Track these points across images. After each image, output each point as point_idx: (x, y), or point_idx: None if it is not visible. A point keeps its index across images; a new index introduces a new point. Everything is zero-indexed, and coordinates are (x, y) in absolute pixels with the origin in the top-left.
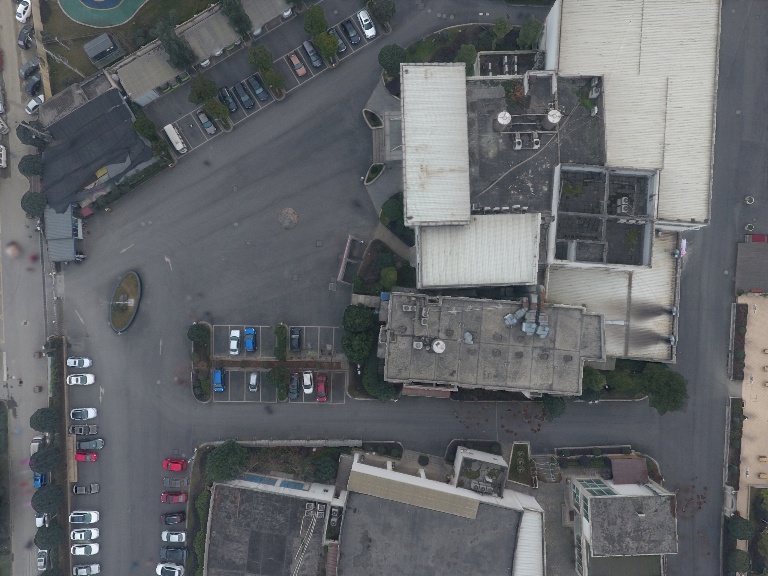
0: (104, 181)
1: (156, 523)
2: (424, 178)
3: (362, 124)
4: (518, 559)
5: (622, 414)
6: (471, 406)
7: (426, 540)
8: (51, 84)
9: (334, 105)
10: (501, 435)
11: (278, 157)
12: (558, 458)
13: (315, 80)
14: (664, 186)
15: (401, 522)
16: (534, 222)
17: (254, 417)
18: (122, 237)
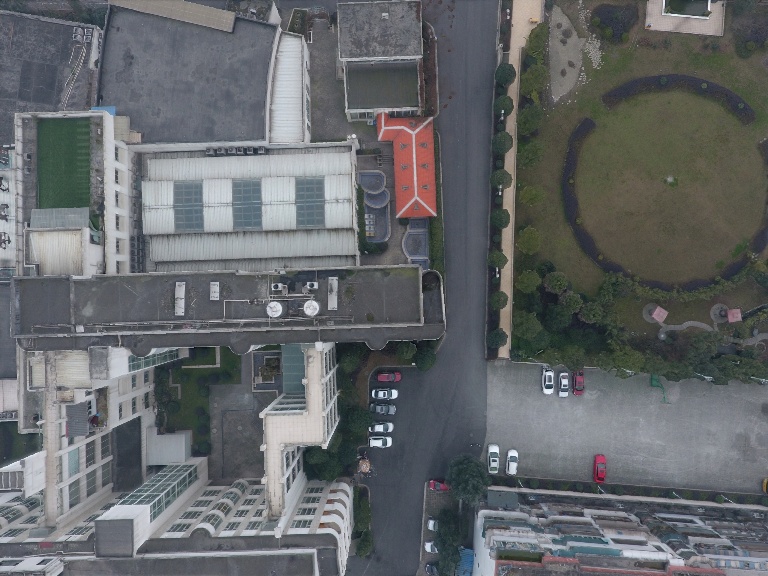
0: None
1: None
2: None
3: None
4: (278, 81)
5: None
6: None
7: (186, 56)
8: None
9: None
10: (282, 2)
11: None
12: None
13: None
14: None
15: (162, 40)
16: None
17: None
18: None
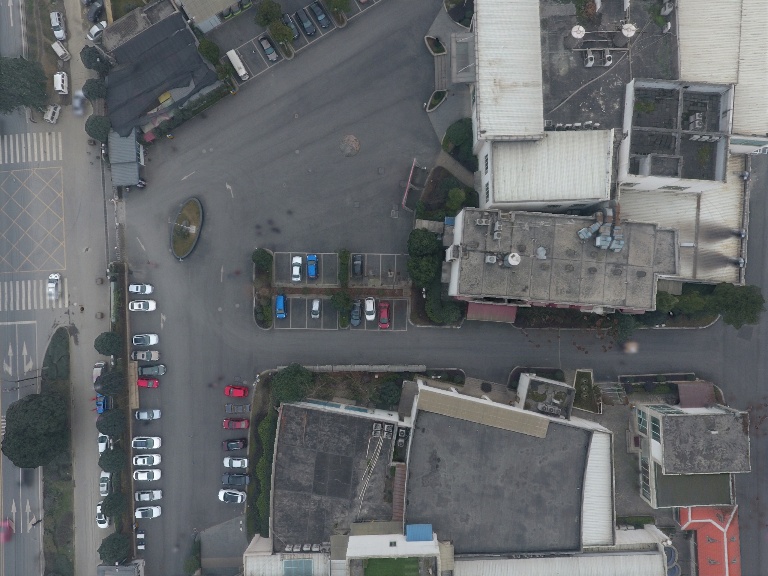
0: (167, 105)
1: (218, 450)
2: (497, 92)
3: (424, 51)
4: (586, 480)
5: (686, 342)
6: (534, 334)
7: (495, 460)
8: (112, 11)
9: (396, 32)
10: (564, 363)
11: (340, 84)
12: (623, 384)
13: (377, 7)
14: (739, 101)
15: (470, 442)
16: (606, 138)
17: (316, 344)
18: (183, 164)
